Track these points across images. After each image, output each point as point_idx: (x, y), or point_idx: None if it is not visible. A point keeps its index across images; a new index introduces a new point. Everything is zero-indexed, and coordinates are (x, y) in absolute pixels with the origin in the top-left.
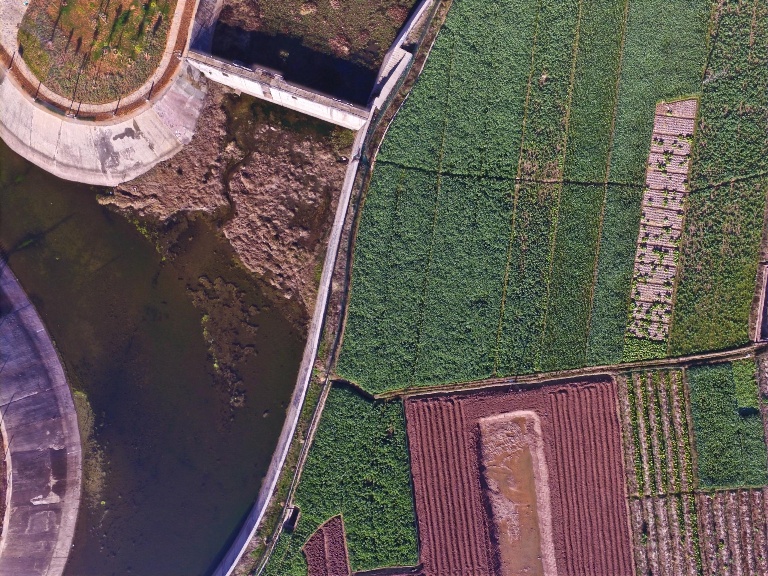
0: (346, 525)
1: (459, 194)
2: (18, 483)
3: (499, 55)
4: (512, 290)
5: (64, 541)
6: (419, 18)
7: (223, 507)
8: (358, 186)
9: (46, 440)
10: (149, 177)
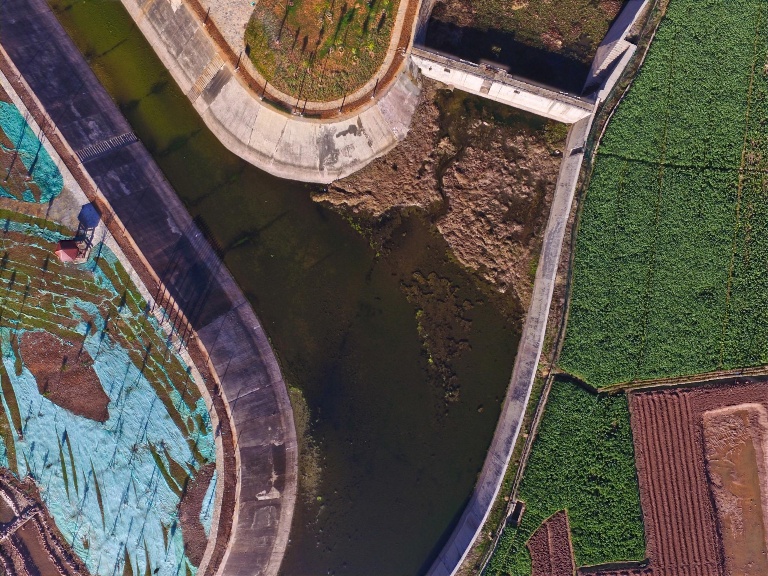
0: (572, 519)
1: (683, 185)
2: (246, 478)
3: (723, 45)
4: (738, 281)
5: (282, 536)
6: (642, 10)
7: (437, 502)
8: (581, 179)
9: (268, 436)
10: (364, 174)
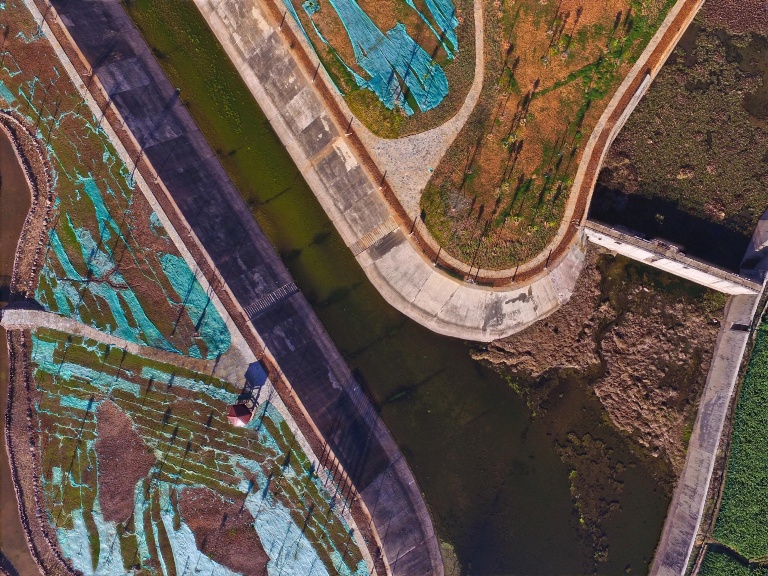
0: None
1: None
2: None
3: None
4: None
5: None
6: None
7: None
8: (743, 355)
9: None
10: (525, 335)
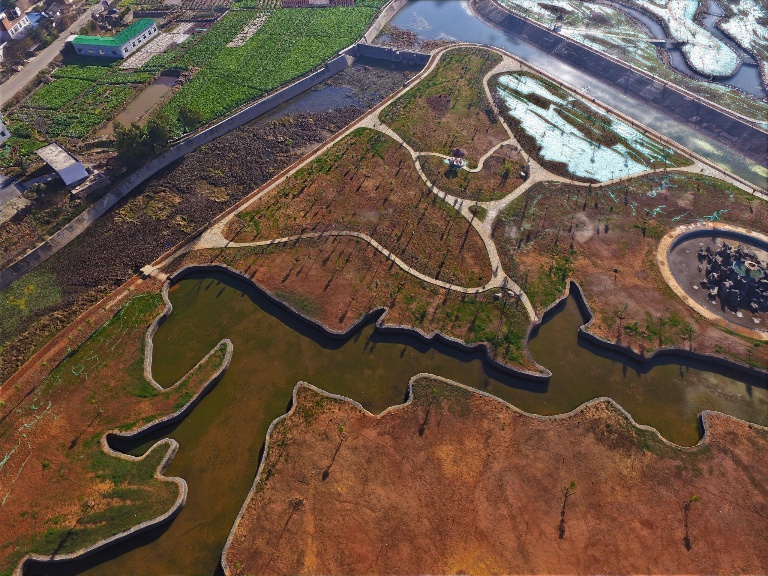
0: None
1: None
2: None
3: None
4: None
5: None
6: None
7: (420, 1)
8: None
9: None
10: None
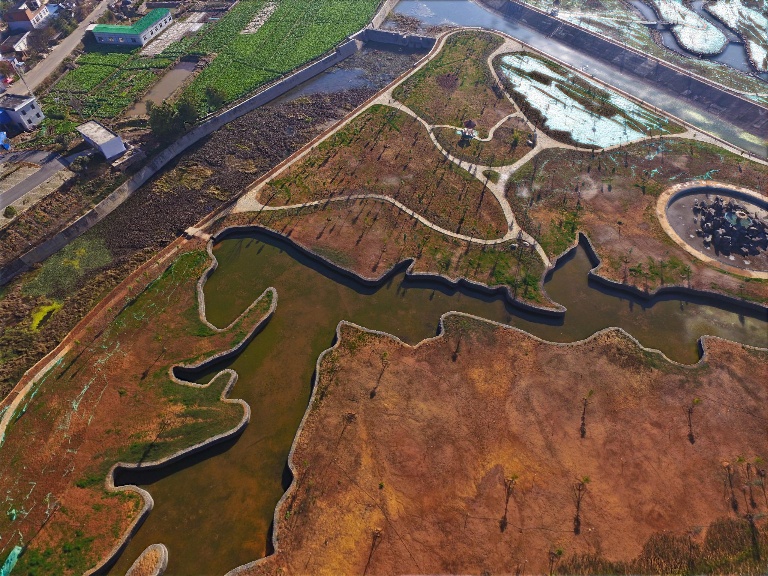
0: None
1: None
2: None
3: None
4: None
5: None
6: None
7: None
8: None
9: None
10: None
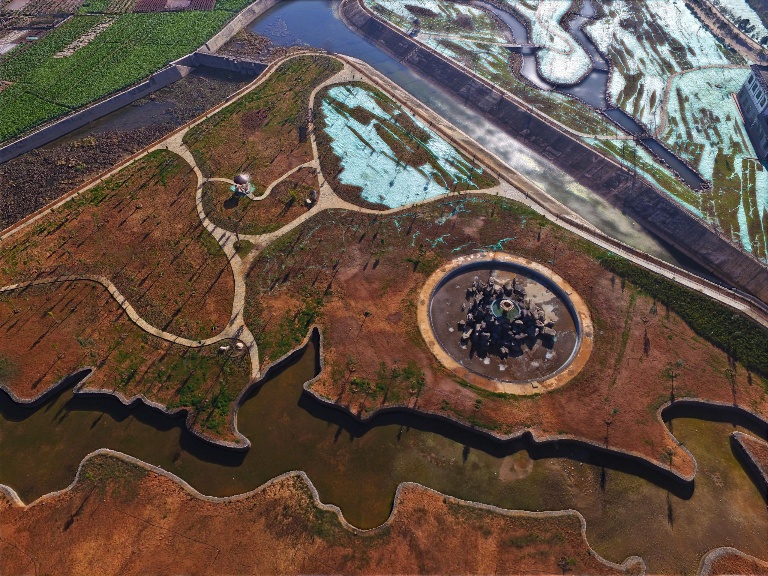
0: None
1: None
2: None
3: None
4: None
5: None
6: None
7: None
8: None
9: None
10: None
